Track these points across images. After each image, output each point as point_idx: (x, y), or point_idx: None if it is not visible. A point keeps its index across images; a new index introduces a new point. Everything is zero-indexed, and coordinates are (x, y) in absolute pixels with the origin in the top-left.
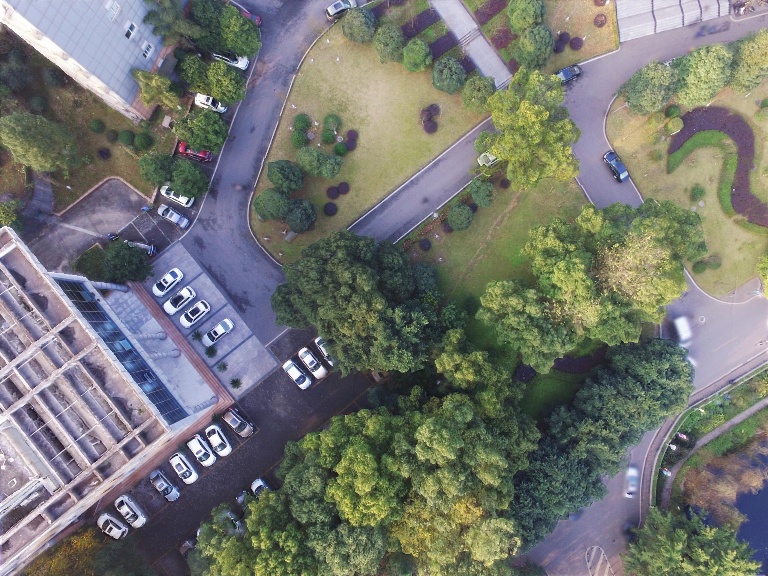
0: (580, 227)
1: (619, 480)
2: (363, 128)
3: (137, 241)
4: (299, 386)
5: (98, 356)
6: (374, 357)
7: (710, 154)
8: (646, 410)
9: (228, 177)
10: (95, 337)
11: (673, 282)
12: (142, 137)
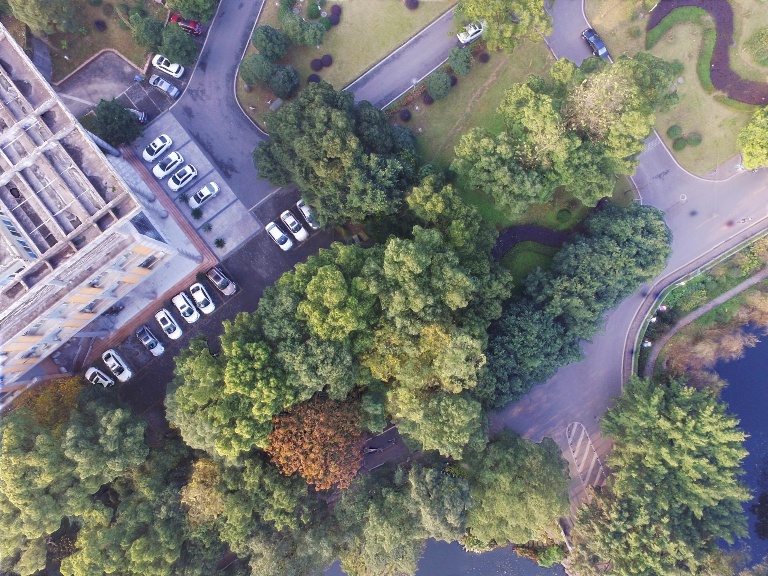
0: (553, 81)
1: (600, 357)
2: (346, 4)
3: (129, 108)
4: (281, 246)
5: (76, 138)
6: (350, 203)
7: (689, 31)
8: (622, 268)
9: (216, 51)
10: (74, 119)
11: (640, 114)
12: (136, 9)
